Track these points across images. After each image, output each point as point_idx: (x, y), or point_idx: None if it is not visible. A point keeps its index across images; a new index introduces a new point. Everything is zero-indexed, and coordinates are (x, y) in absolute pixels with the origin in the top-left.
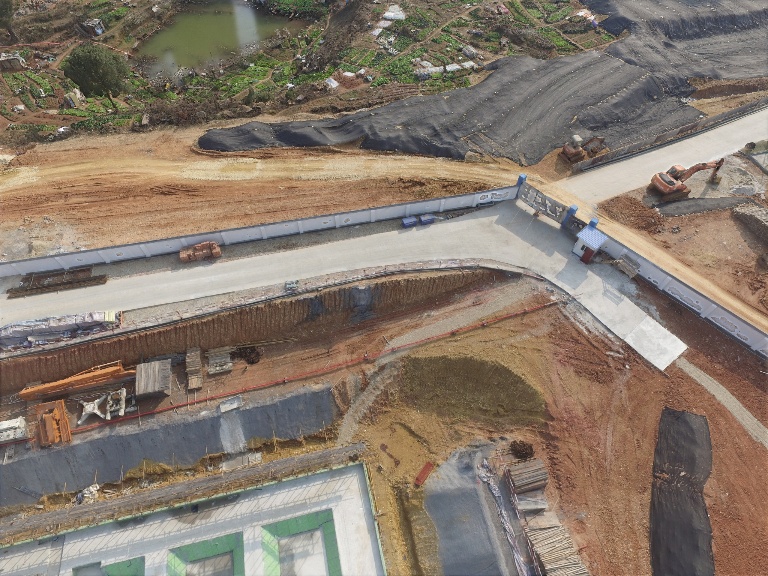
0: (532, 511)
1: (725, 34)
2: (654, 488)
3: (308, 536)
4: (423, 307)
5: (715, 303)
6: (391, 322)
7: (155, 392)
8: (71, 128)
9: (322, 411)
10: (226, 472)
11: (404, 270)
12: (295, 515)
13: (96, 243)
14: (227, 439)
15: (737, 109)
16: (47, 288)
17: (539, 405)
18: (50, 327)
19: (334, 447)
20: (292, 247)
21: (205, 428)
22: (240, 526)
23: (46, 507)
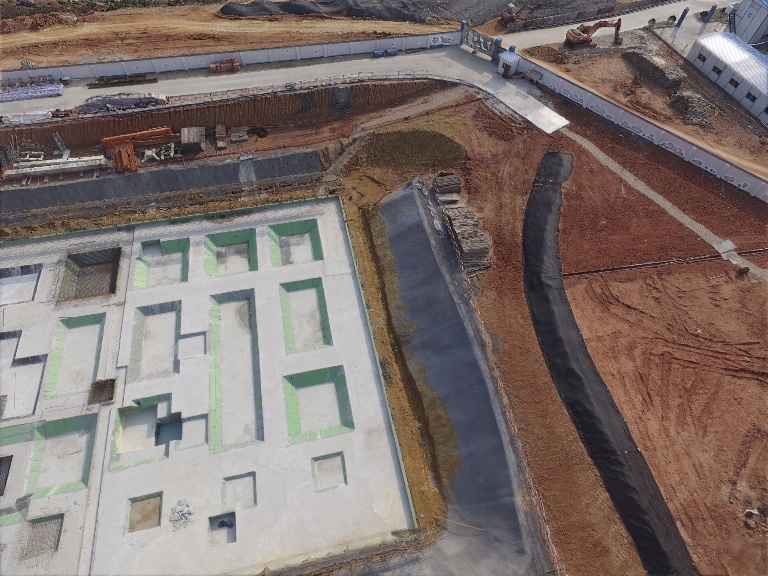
0: (449, 202)
1: None
2: (532, 191)
3: (300, 236)
4: (386, 106)
5: (590, 92)
6: (362, 115)
7: (195, 144)
8: (121, 2)
9: (311, 167)
10: (245, 182)
11: (372, 79)
12: (291, 221)
13: None
14: (244, 180)
15: (649, 1)
16: (116, 84)
17: (461, 153)
18: (122, 99)
19: (318, 172)
20: (291, 66)
21: (229, 171)
22: (253, 225)
23: (120, 214)
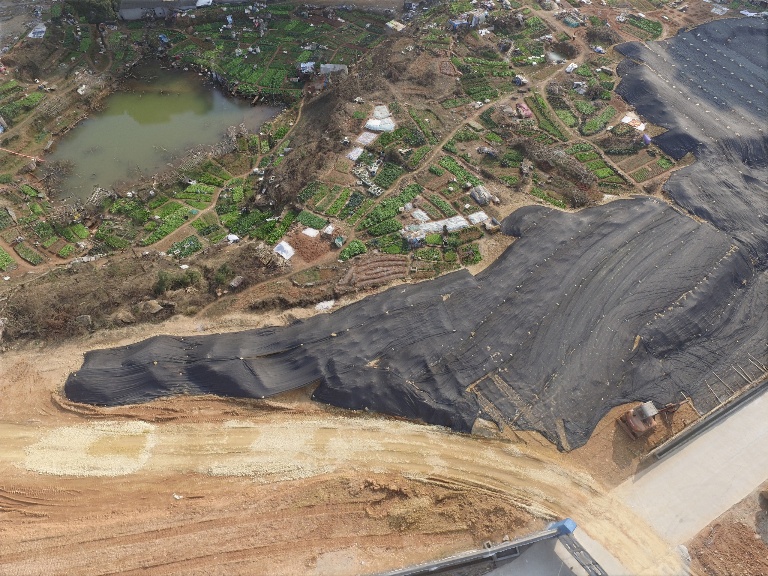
0: None
1: None
2: None
3: None
4: None
5: None
6: None
7: None
8: None
9: None
10: None
11: None
12: None
13: None
14: None
15: None
16: None
17: None
18: None
19: None
20: None
21: None
22: None
23: None
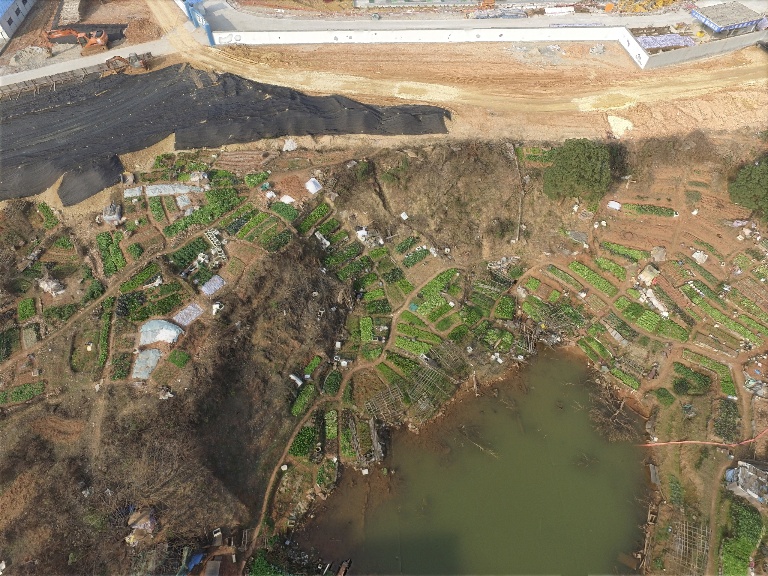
0: None
1: None
2: None
3: None
4: None
5: None
6: None
7: None
8: None
9: None
10: None
11: None
12: (384, 3)
13: (499, 50)
14: None
15: None
16: None
17: None
18: None
19: None
20: None
21: None
22: (406, 3)
23: None
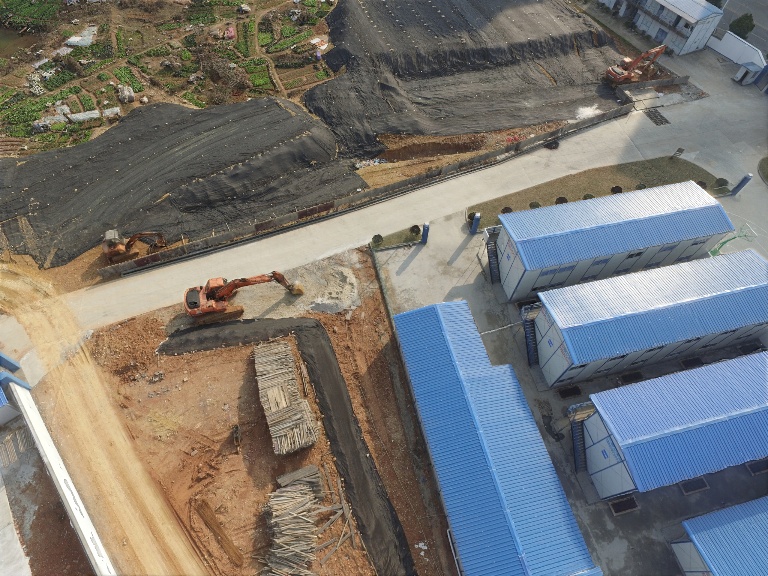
0: None
1: (473, 71)
2: None
3: None
4: None
5: (71, 521)
6: None
7: None
8: None
9: None
10: None
11: None
12: None
13: None
14: None
15: (403, 182)
16: None
17: None
18: None
19: None
20: None
21: None
22: None
23: None
